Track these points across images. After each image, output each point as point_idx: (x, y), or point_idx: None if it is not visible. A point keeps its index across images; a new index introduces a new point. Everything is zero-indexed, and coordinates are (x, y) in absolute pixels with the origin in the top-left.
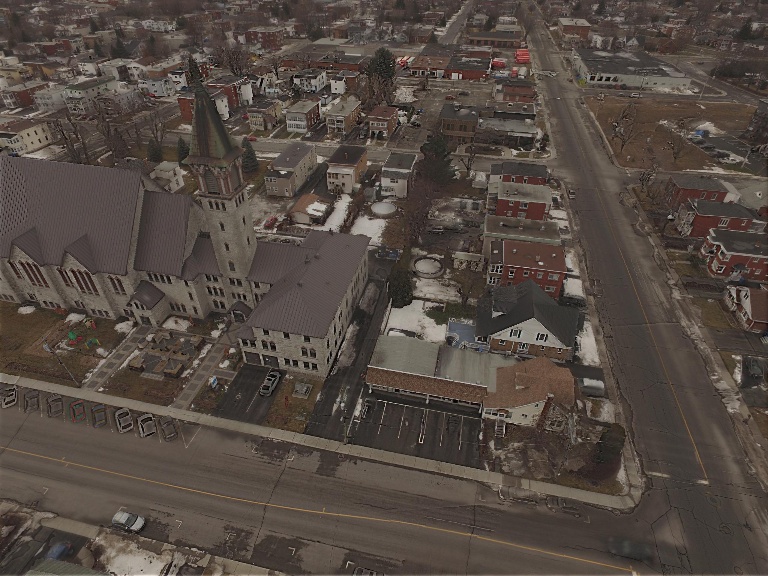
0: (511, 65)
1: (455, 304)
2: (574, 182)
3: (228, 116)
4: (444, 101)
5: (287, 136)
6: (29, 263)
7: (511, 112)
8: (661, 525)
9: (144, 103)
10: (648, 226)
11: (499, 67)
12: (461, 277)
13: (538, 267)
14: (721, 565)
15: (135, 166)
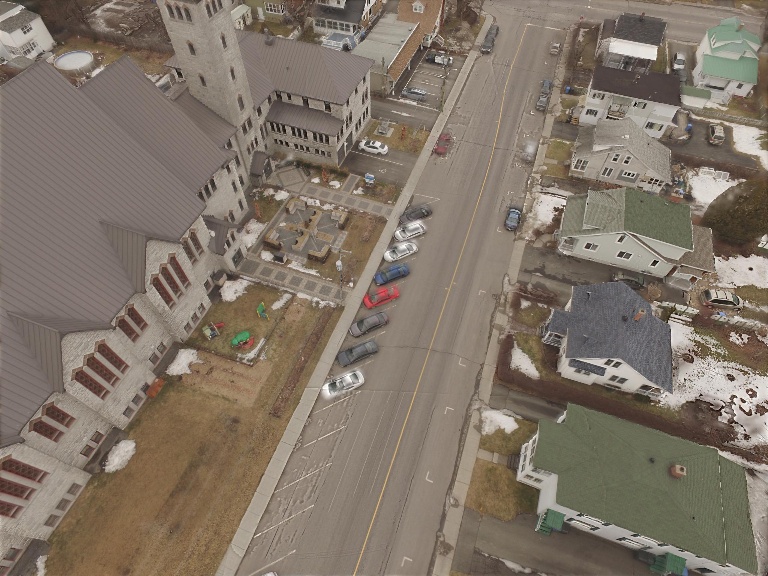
0: None
1: None
2: None
3: None
4: None
5: None
6: (89, 355)
7: None
8: (502, 11)
9: None
10: None
11: None
12: None
13: None
14: (522, 2)
15: None
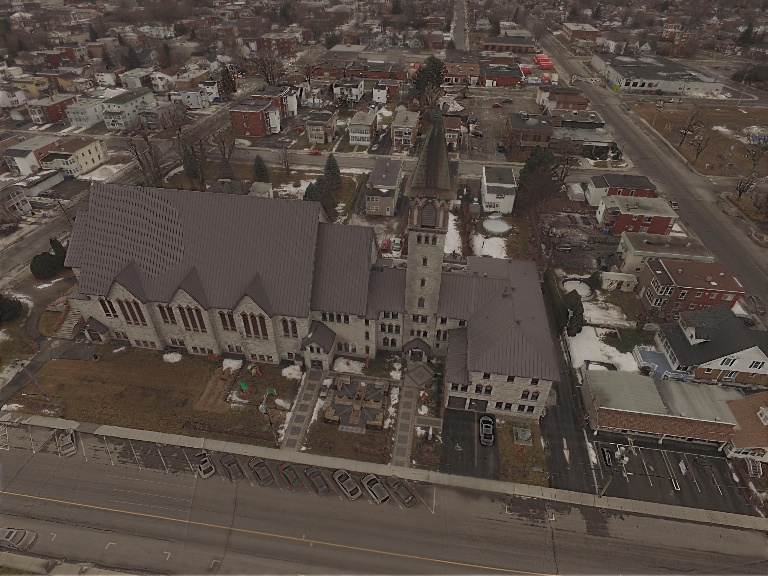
0: (536, 71)
1: (627, 329)
2: (667, 192)
3: (279, 129)
4: (493, 109)
5: (352, 149)
6: (190, 307)
7: (580, 121)
8: None
9: (186, 116)
10: (765, 236)
11: (525, 73)
12: (615, 299)
13: (713, 288)
14: None
15: (232, 188)
